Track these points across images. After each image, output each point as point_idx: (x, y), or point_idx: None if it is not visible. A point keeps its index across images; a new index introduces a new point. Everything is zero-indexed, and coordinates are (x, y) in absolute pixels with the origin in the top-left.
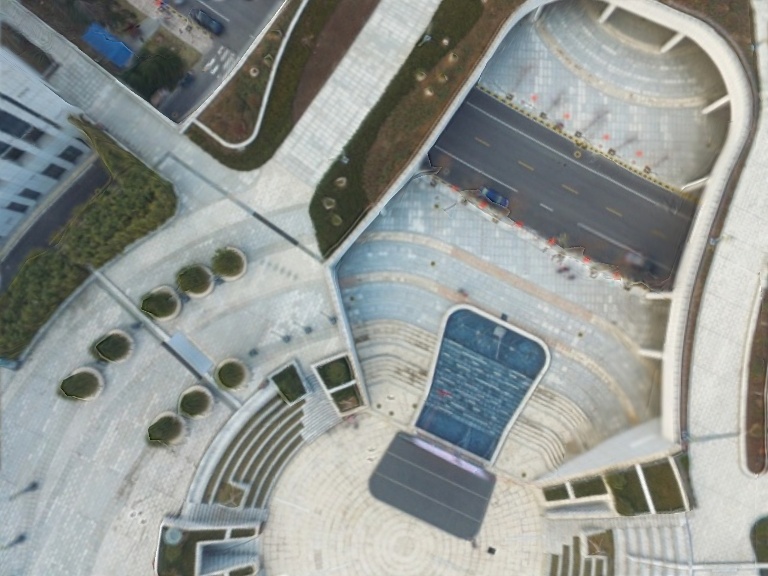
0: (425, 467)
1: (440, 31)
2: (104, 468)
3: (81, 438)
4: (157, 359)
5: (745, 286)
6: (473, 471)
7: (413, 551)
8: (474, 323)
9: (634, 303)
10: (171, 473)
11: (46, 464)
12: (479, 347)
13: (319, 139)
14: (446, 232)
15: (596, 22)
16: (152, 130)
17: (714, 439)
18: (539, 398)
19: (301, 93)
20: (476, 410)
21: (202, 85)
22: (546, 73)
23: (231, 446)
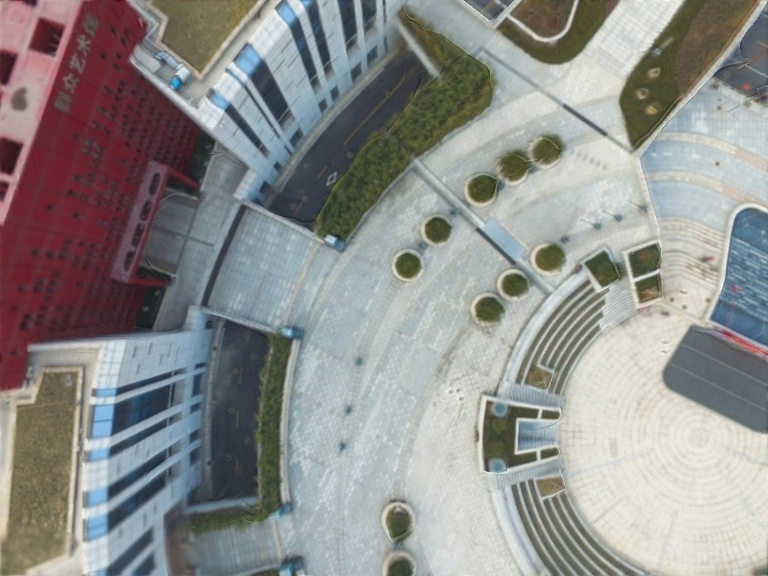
0: (721, 360)
1: None
2: (423, 347)
3: (402, 317)
4: (472, 244)
5: None
6: None
7: (707, 442)
8: (760, 222)
9: None
10: (487, 353)
11: (369, 341)
12: (764, 247)
13: (629, 32)
14: (730, 133)
15: None
16: (466, 26)
17: None
18: None
19: None
20: None
21: None
22: None
23: (543, 329)
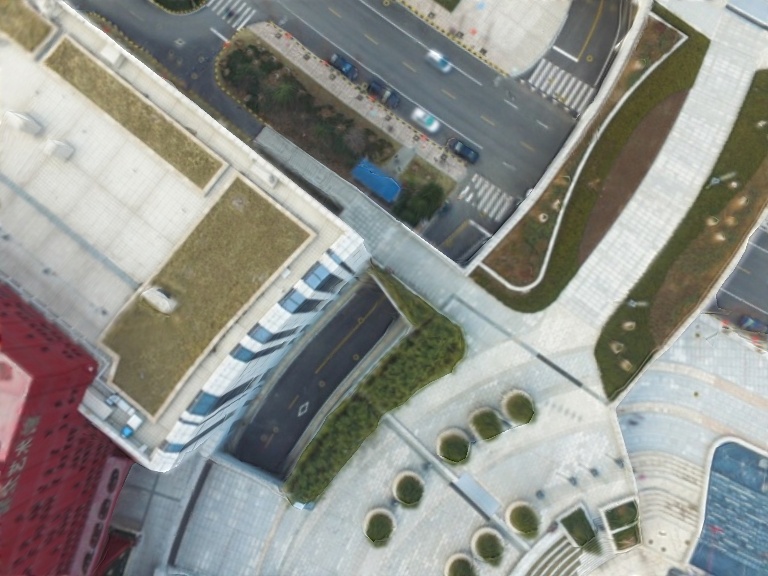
0: None
1: (728, 173)
2: None
3: None
4: (445, 499)
5: None
6: None
7: None
8: (740, 455)
9: None
10: None
11: None
12: (744, 479)
13: (604, 281)
14: (708, 362)
15: None
16: (437, 272)
17: None
18: None
19: (587, 237)
20: (750, 547)
21: (458, 213)
22: None
23: None
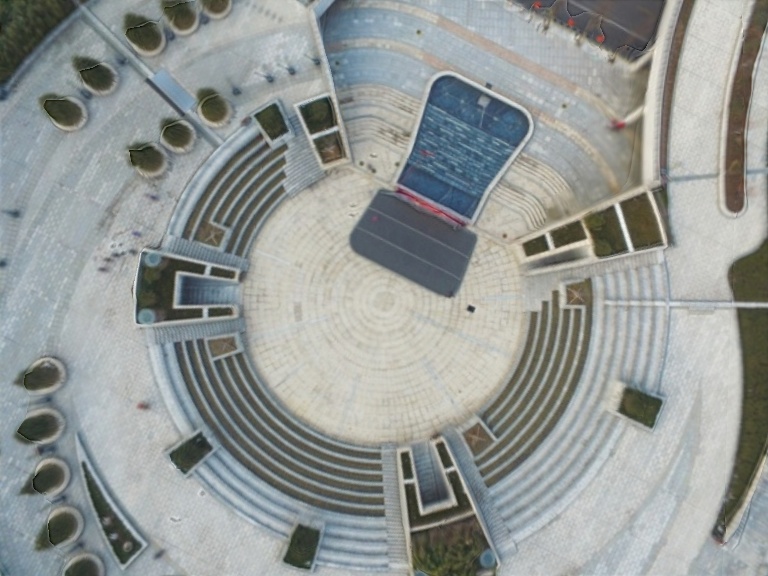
0: (406, 223)
1: None
2: (86, 199)
3: (63, 169)
4: (141, 95)
5: (727, 29)
6: (454, 224)
7: (393, 306)
8: (458, 91)
9: (618, 75)
10: (152, 207)
11: (28, 193)
12: (463, 116)
13: None
14: (432, 2)
15: None
16: None
17: (693, 179)
18: (522, 164)
19: None
20: (458, 171)
21: None
22: None
23: (212, 183)
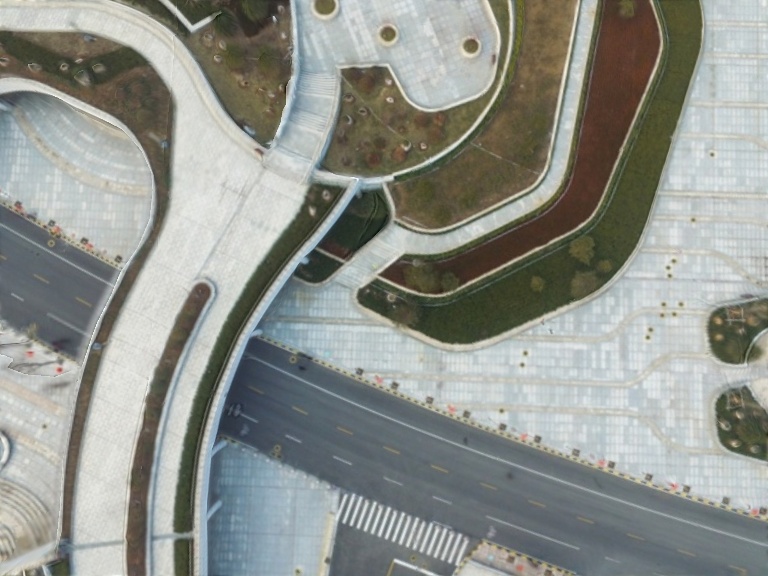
0: None
1: None
2: None
3: None
4: None
5: (134, 391)
6: None
7: None
8: None
9: None
10: None
11: None
12: None
13: None
14: None
15: (72, 110)
16: None
17: (99, 547)
18: None
19: None
20: None
21: None
22: (23, 161)
23: None
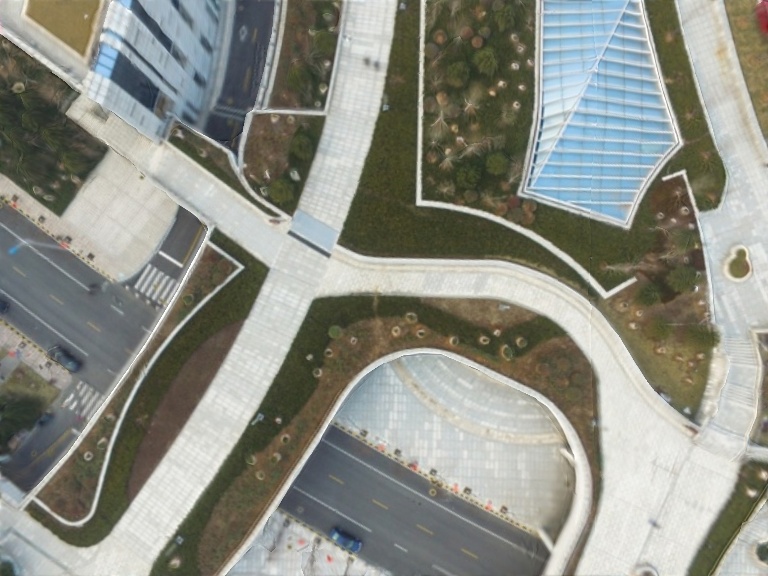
0: None
1: (273, 409)
2: None
3: None
4: None
5: None
6: None
7: None
8: None
9: None
10: None
11: None
12: None
13: (155, 516)
14: (299, 574)
15: None
16: None
17: None
18: None
19: (136, 473)
20: None
21: (61, 422)
22: (401, 408)
23: None
